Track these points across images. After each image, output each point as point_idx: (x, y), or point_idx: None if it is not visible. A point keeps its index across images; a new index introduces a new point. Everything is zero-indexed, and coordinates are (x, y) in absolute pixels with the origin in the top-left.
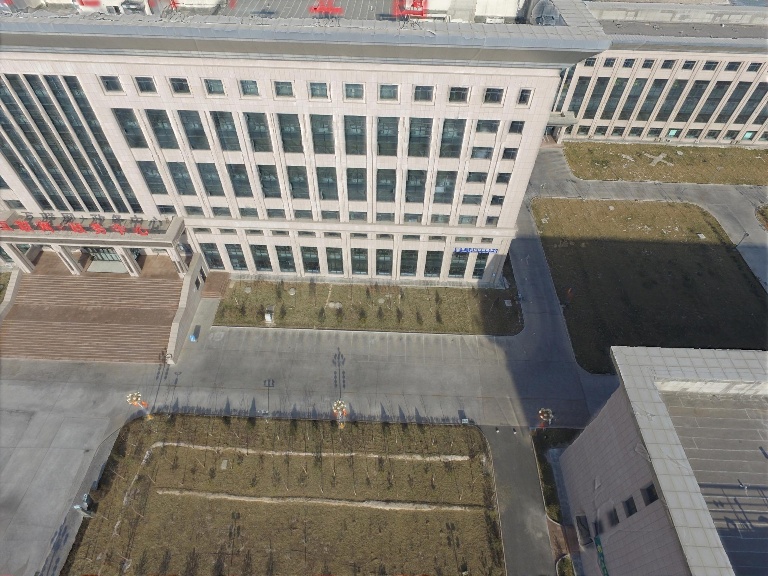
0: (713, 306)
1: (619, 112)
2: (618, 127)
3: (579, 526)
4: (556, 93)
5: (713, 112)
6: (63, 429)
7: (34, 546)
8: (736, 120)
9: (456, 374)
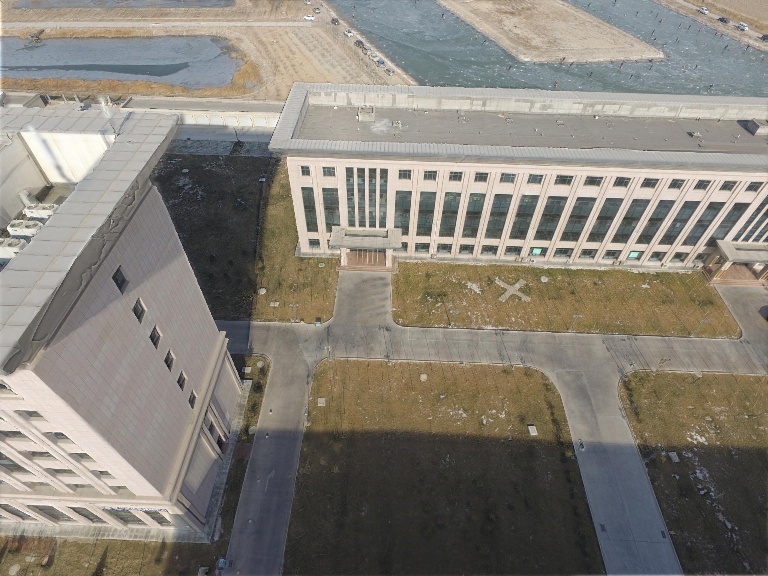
0: None
1: (461, 229)
2: (466, 245)
3: None
4: (48, 385)
5: (582, 231)
6: None
7: None
8: (614, 239)
9: None
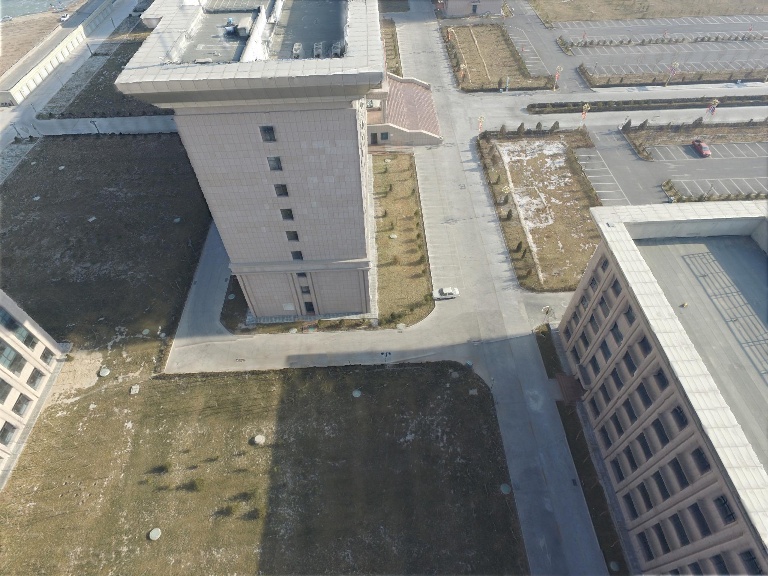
0: None
1: None
2: None
3: (475, 3)
4: None
5: None
6: (474, 107)
7: (522, 99)
8: None
9: (417, 31)
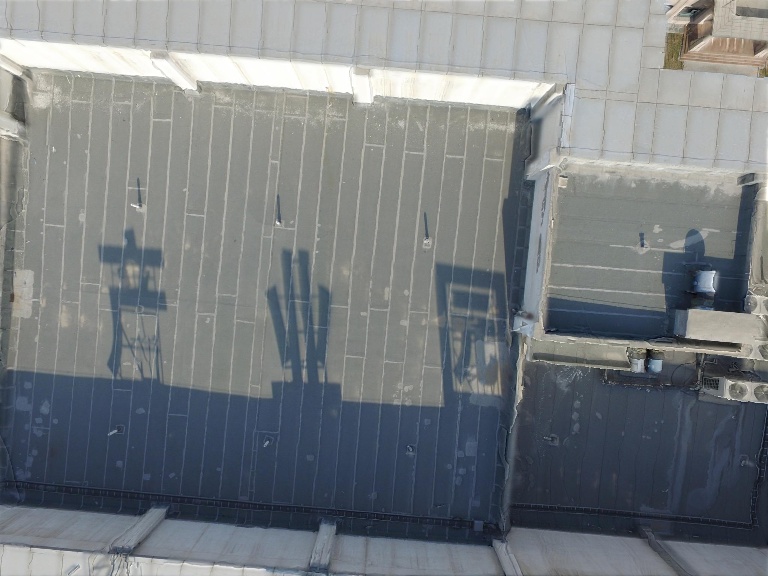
0: None
1: None
2: None
3: None
4: None
5: None
6: None
7: None
8: None
9: None
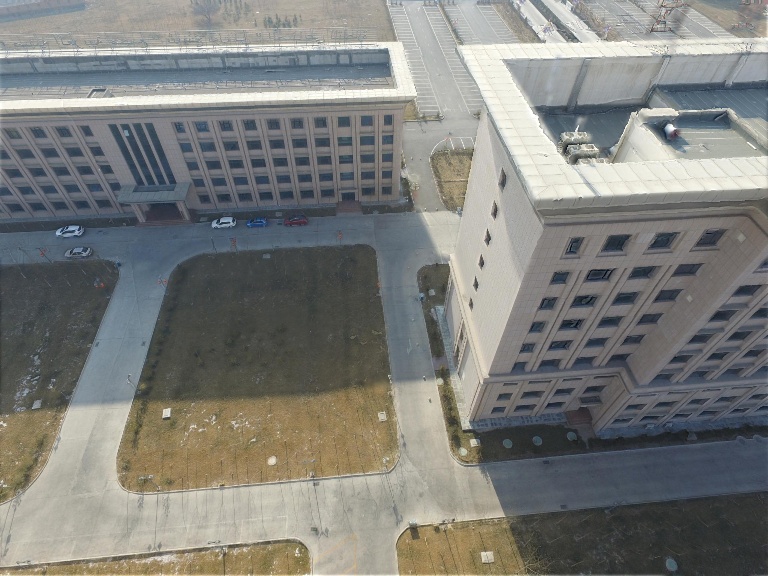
0: (225, 312)
1: None
2: None
3: None
4: None
5: None
6: None
7: None
8: None
9: None
